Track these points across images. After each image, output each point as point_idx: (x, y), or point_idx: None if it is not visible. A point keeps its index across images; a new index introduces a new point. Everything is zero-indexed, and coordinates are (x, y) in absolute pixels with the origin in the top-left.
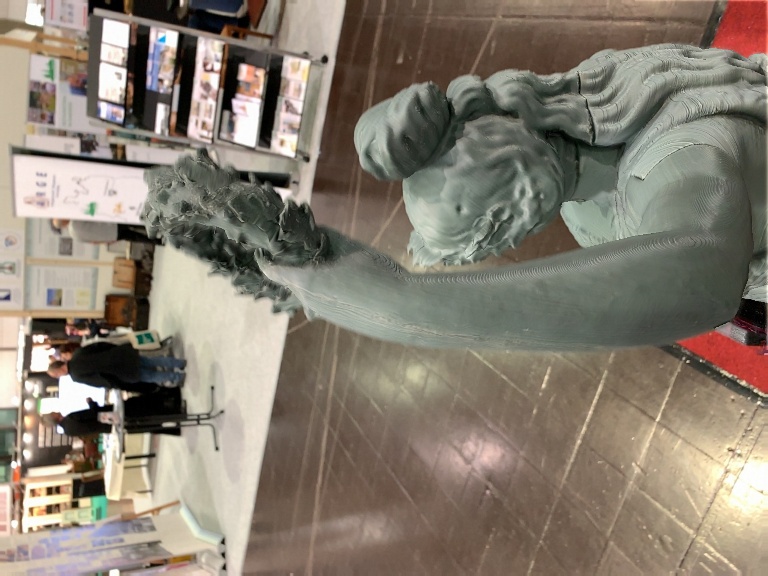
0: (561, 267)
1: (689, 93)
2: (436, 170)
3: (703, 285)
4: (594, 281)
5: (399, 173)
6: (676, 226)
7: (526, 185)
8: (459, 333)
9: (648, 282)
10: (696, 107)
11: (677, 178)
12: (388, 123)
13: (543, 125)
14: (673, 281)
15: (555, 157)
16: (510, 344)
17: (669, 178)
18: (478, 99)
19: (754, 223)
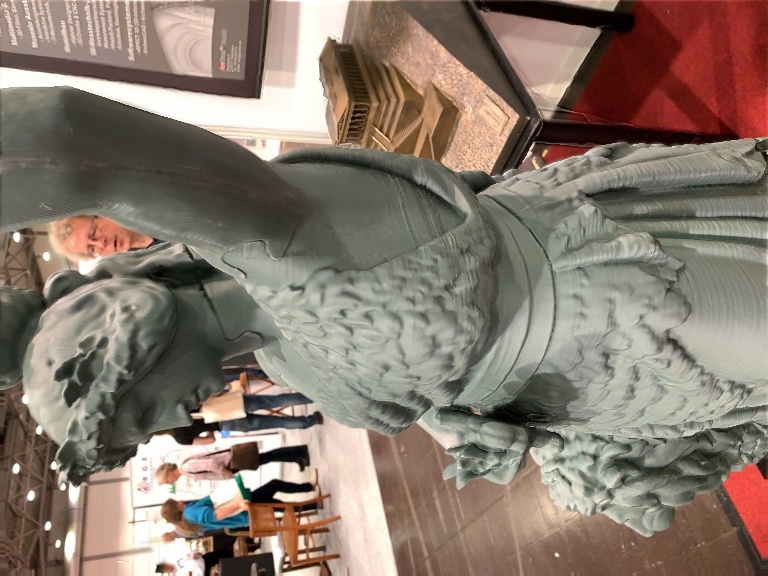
0: None
1: None
2: (28, 347)
3: None
4: None
5: None
6: None
7: (116, 308)
8: None
9: None
10: None
11: None
12: None
13: (137, 269)
14: None
15: (154, 283)
16: None
17: None
18: (63, 277)
19: (388, 229)
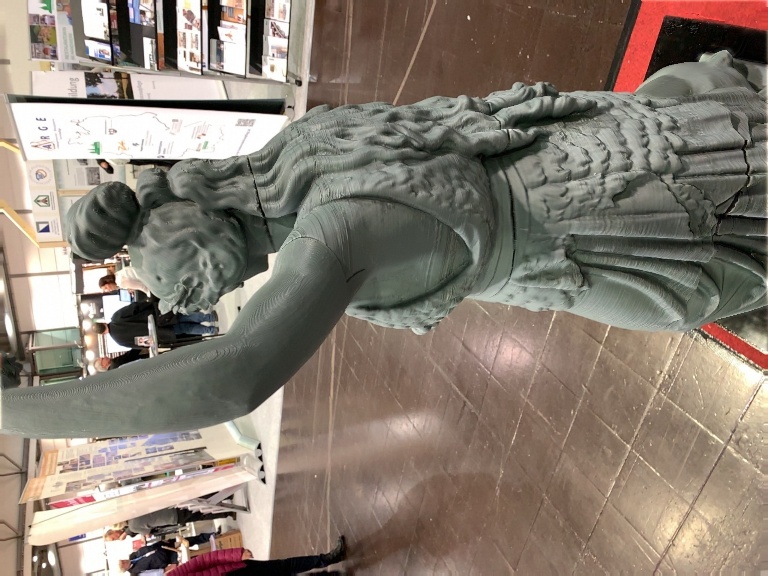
0: (106, 385)
1: (326, 178)
2: (135, 249)
3: (210, 393)
4: (125, 396)
5: (95, 259)
6: (230, 332)
7: (207, 258)
8: (40, 433)
9: (165, 395)
10: (325, 193)
11: (277, 271)
12: (76, 222)
13: (217, 207)
14: (184, 393)
15: (232, 231)
16: (83, 437)
17: (275, 269)
18: (153, 193)
19: (414, 273)
